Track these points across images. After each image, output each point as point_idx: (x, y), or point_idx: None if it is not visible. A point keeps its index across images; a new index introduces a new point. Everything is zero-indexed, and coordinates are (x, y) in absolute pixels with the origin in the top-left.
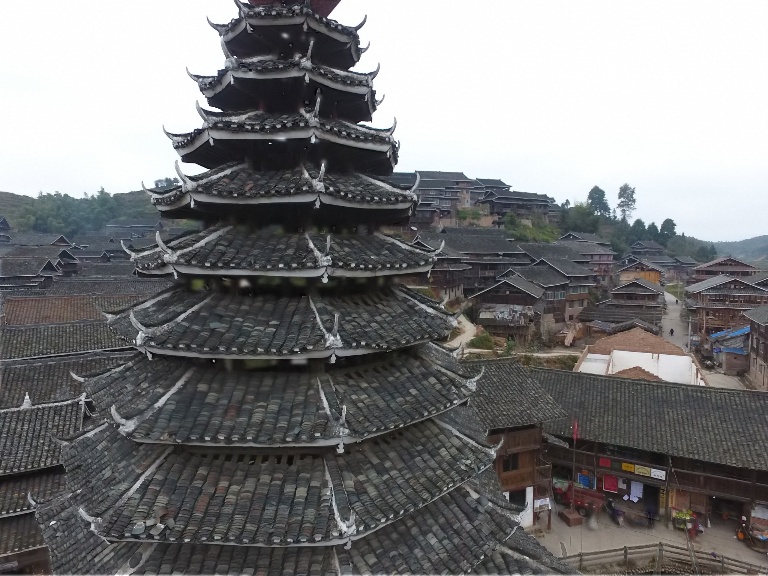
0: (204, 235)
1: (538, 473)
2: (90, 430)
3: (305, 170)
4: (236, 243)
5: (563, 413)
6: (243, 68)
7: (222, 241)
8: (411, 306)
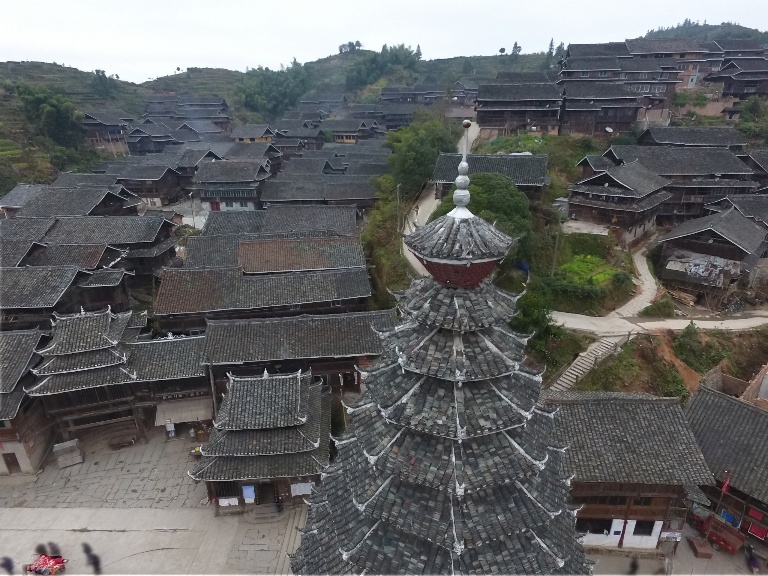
0: (381, 484)
1: (672, 512)
2: (315, 529)
3: (453, 449)
4: (402, 492)
5: (710, 480)
6: (412, 363)
7: (393, 488)
8: (529, 538)
